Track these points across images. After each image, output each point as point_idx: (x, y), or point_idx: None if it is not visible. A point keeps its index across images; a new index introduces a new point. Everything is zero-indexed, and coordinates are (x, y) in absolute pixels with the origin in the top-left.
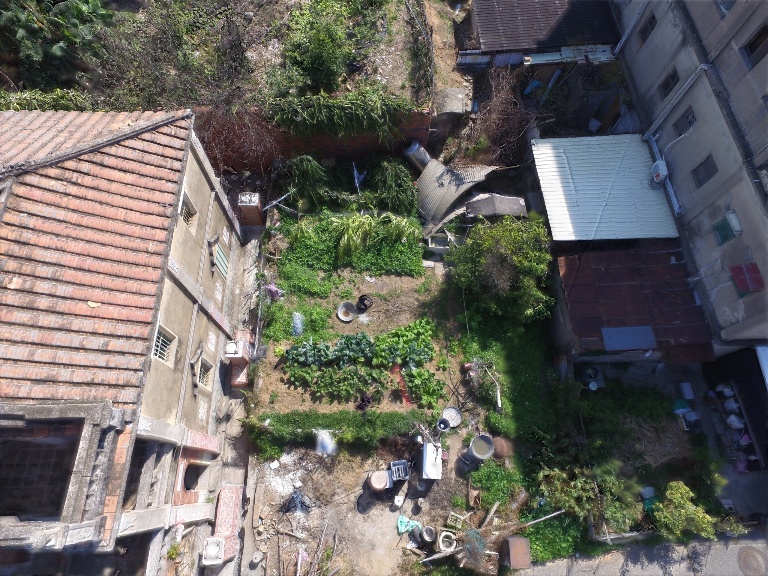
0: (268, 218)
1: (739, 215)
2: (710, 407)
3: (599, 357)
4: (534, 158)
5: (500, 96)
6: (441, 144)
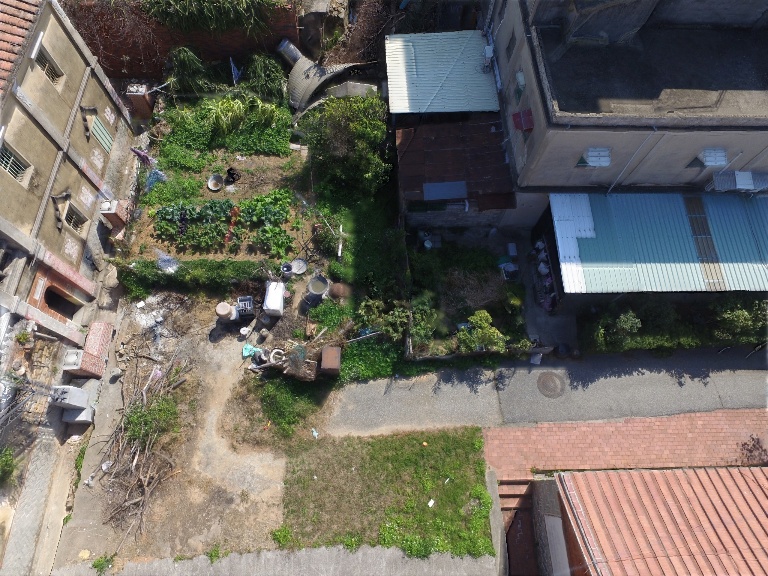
0: (155, 108)
1: (524, 72)
2: (531, 263)
3: (430, 215)
4: (385, 50)
5: (366, 2)
6: (317, 48)
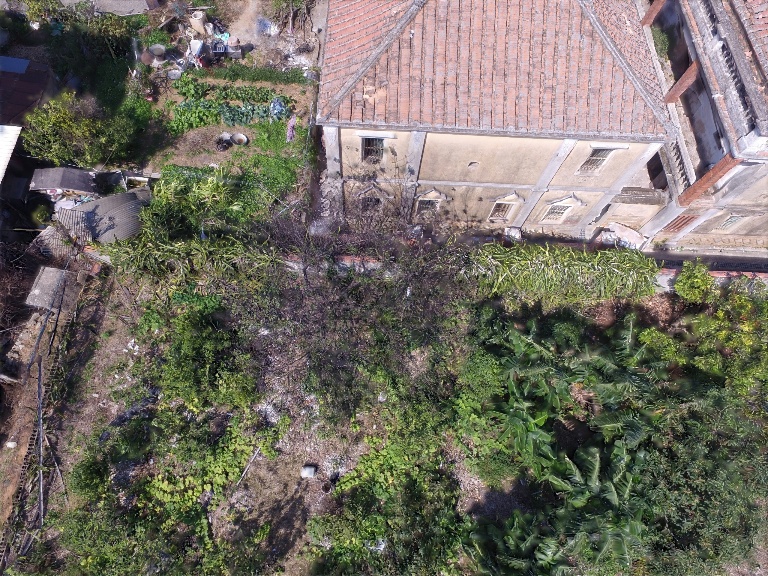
0: None
1: None
2: None
3: None
4: None
5: None
6: None
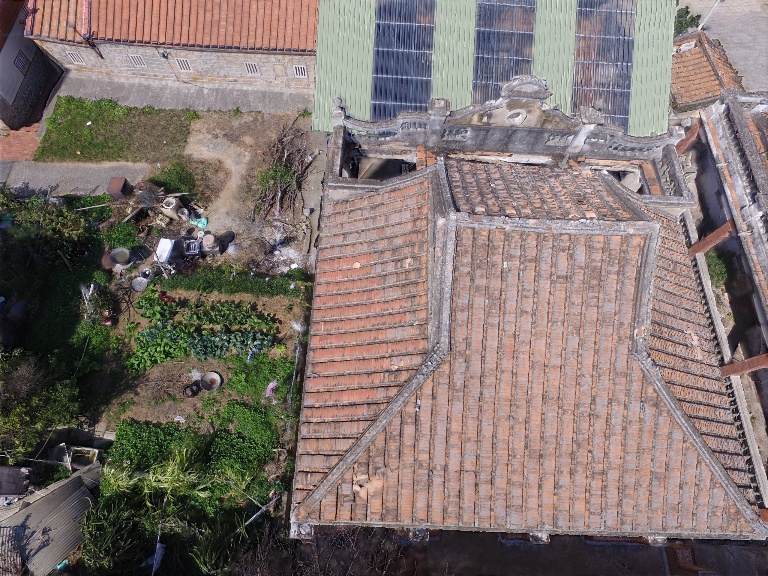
0: (284, 507)
1: None
2: None
3: None
4: None
5: None
6: None
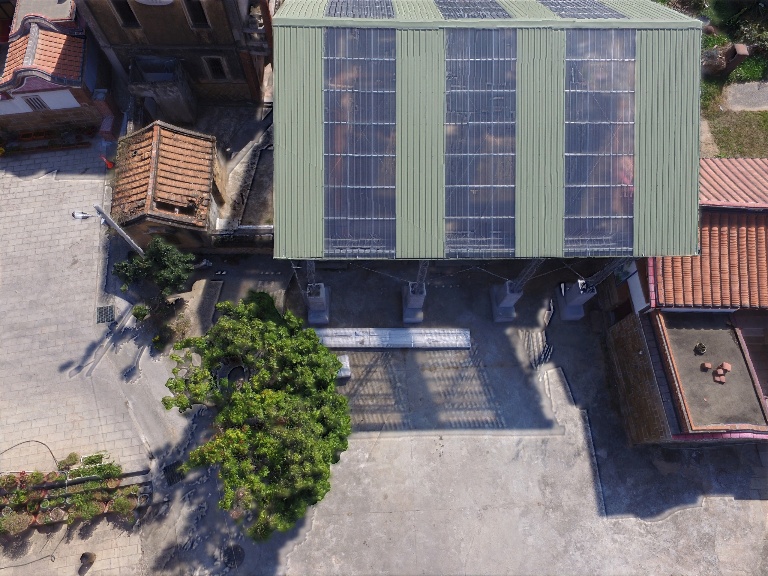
0: None
1: None
2: None
3: None
4: None
5: None
6: None
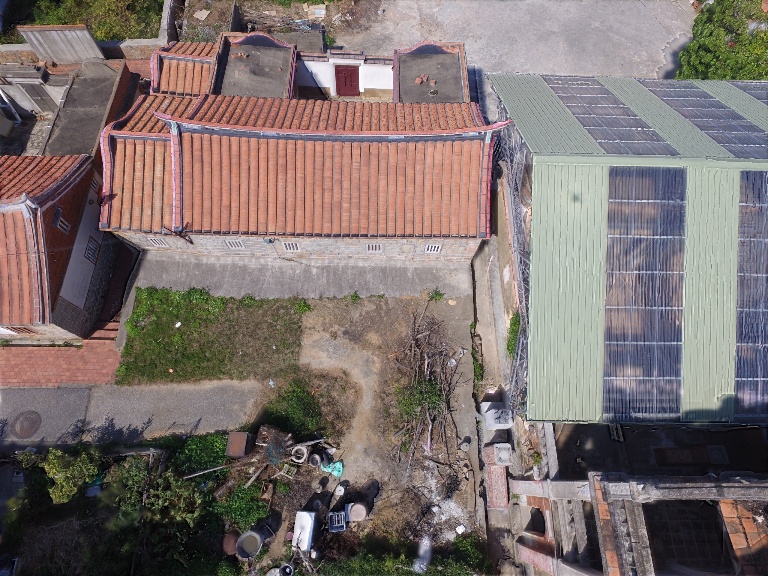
0: None
1: None
2: None
3: None
4: None
5: None
6: None
